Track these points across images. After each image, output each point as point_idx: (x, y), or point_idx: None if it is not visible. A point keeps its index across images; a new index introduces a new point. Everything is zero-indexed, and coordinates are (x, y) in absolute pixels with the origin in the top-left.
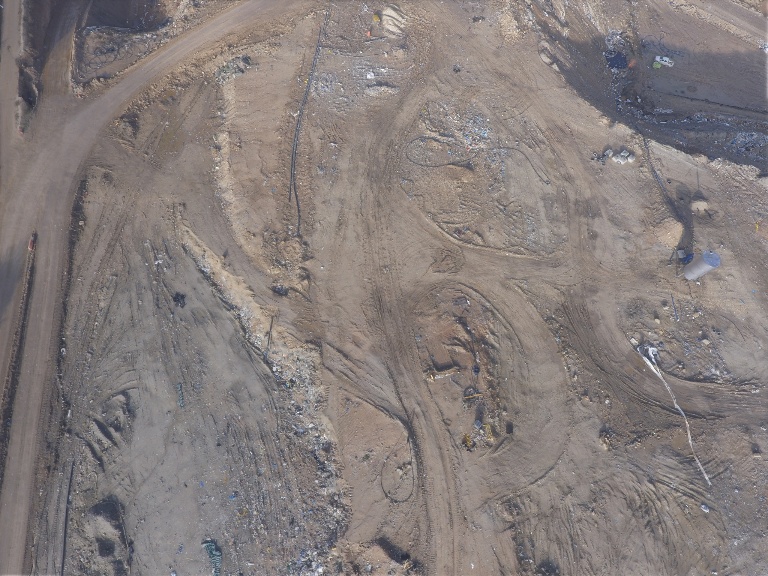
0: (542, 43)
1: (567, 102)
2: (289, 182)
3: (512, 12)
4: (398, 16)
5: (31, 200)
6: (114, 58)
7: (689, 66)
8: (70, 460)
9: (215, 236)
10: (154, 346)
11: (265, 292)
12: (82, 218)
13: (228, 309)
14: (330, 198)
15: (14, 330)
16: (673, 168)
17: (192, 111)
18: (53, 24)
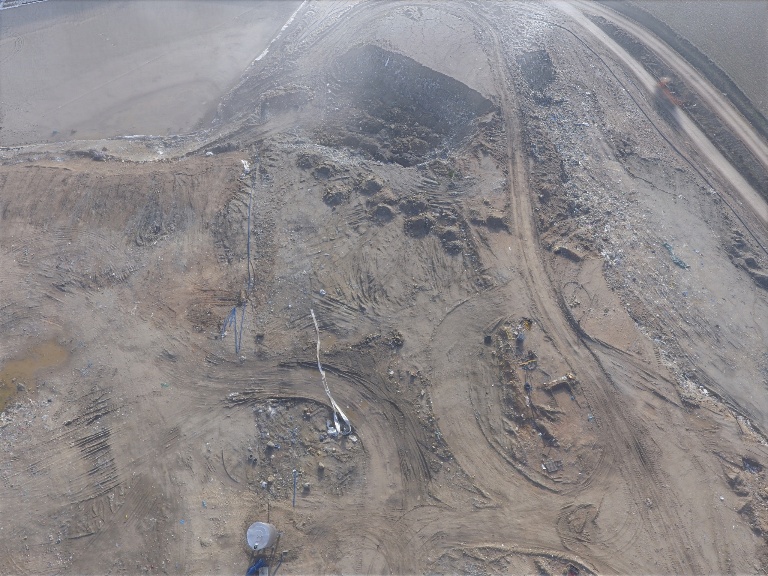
0: None
1: None
2: None
3: None
4: None
5: None
6: None
7: None
8: None
9: None
10: None
11: (767, 462)
12: None
13: None
14: None
15: None
16: None
17: None
18: None
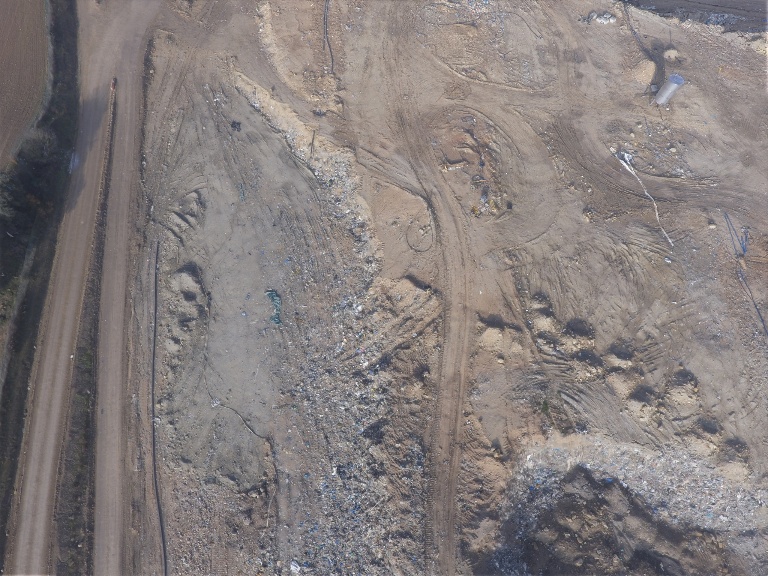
0: None
1: None
2: (323, 36)
3: None
4: None
5: (110, 54)
6: None
7: None
8: (156, 240)
9: (263, 77)
10: (218, 158)
11: (307, 114)
12: (152, 68)
13: (276, 132)
14: (357, 47)
15: (104, 148)
16: (649, 27)
17: None
18: None
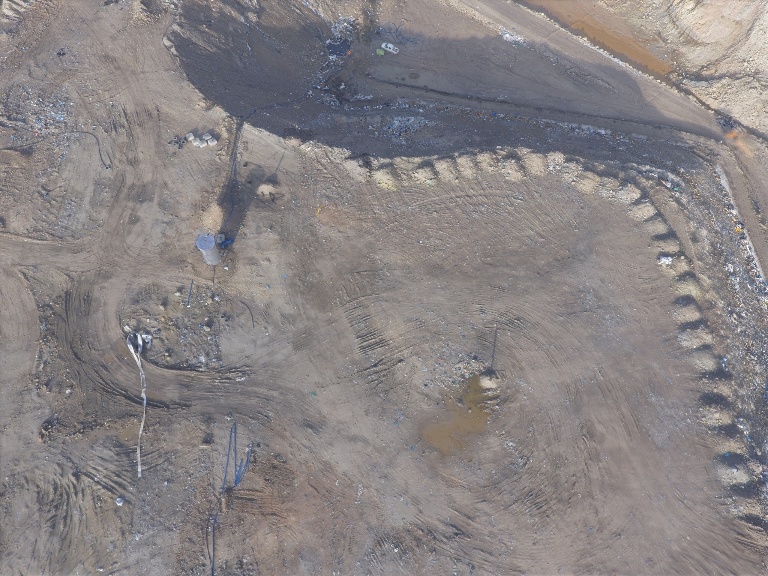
0: (173, 26)
1: (169, 85)
2: None
3: None
4: None
5: None
6: None
7: (419, 53)
8: None
9: None
10: None
11: None
12: None
13: None
14: None
15: None
16: (257, 151)
17: None
18: None
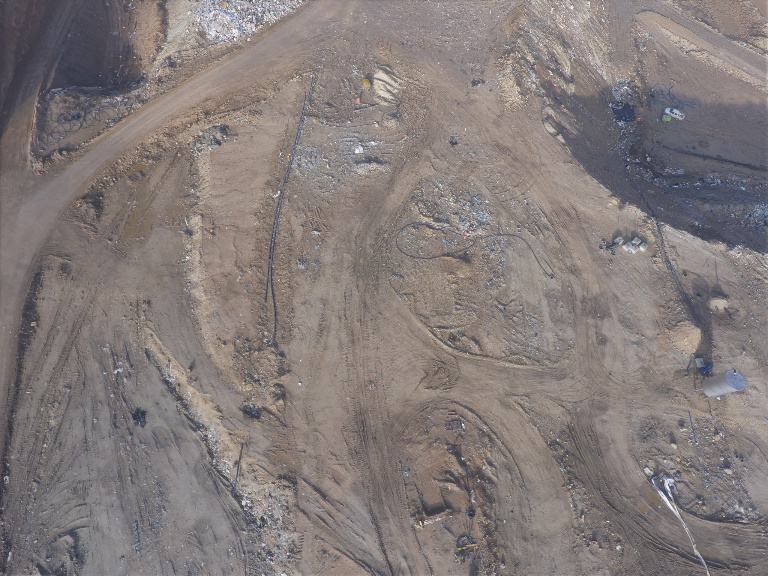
0: (546, 110)
1: (573, 180)
2: (266, 278)
3: (514, 76)
4: (390, 80)
5: None
6: (79, 126)
7: (700, 118)
8: None
9: (181, 342)
10: (109, 475)
11: (235, 414)
12: (34, 318)
13: (194, 429)
14: (311, 298)
15: None
16: (689, 257)
17: (163, 188)
18: (15, 85)
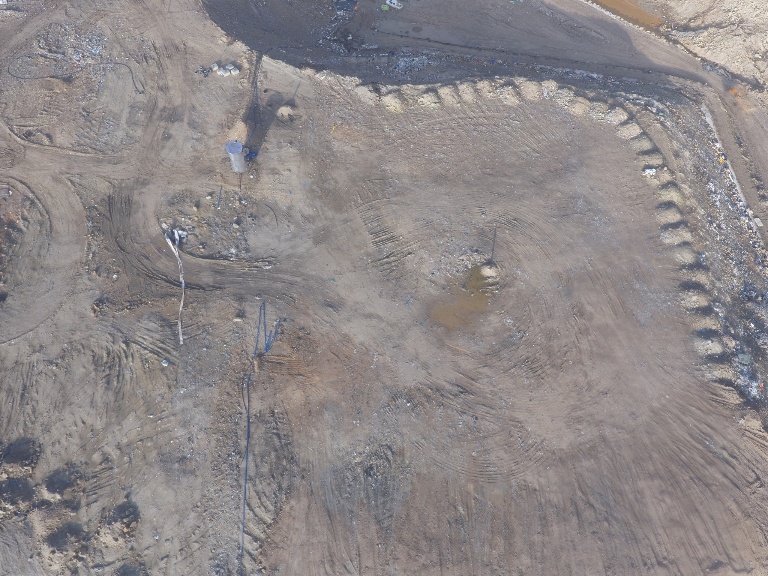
0: None
1: (193, 23)
2: None
3: None
4: None
5: None
6: None
7: (422, 9)
8: None
9: None
10: None
11: None
12: None
13: None
14: None
15: None
16: (276, 80)
17: None
18: None
